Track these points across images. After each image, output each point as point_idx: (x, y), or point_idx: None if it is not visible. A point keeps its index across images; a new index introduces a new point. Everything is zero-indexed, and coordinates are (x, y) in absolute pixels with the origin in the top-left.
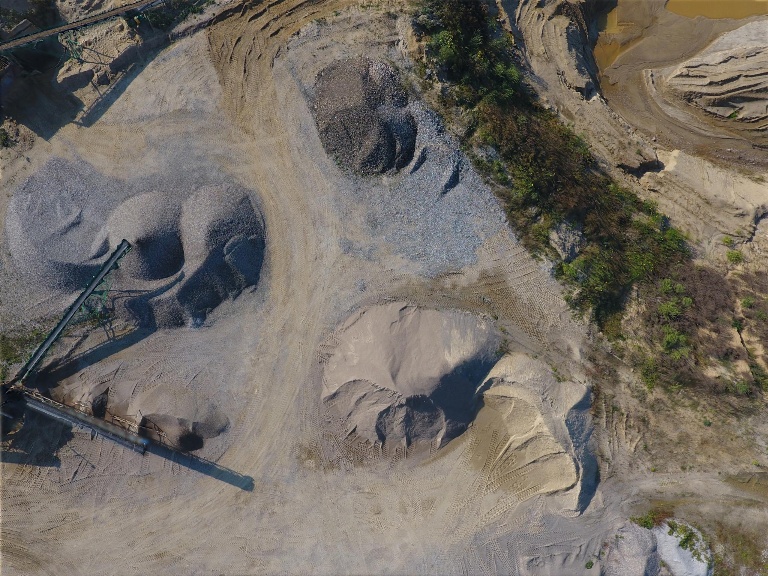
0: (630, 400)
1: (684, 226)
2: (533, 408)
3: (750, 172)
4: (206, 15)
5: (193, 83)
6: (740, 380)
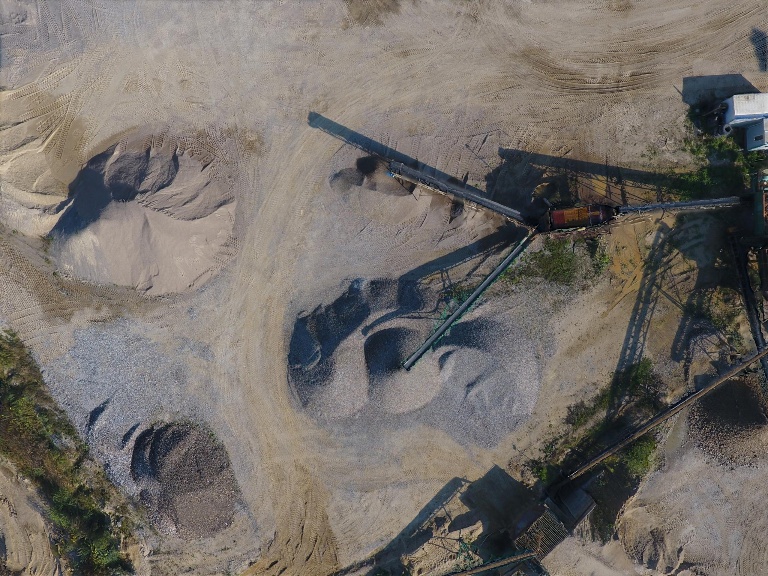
0: None
1: None
2: (10, 181)
3: None
4: None
5: (354, 517)
6: None
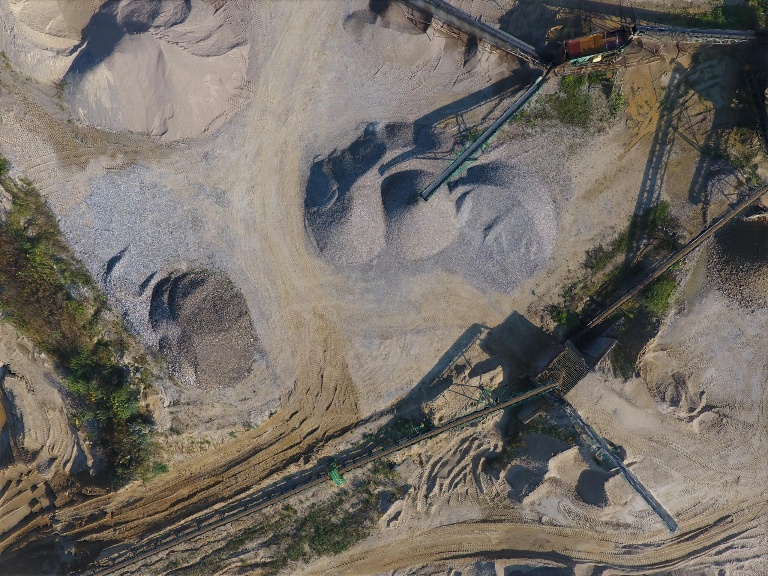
0: None
1: None
2: (23, 21)
3: None
4: (360, 432)
5: (373, 365)
6: None
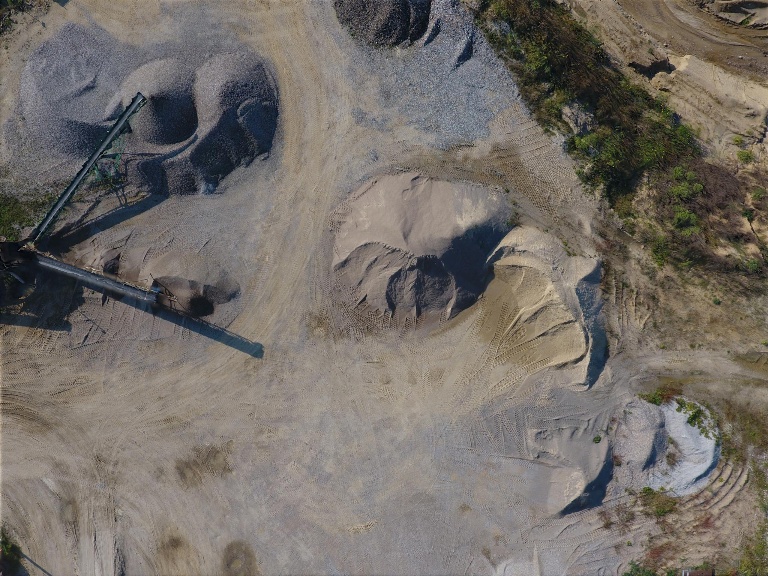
0: (640, 277)
1: (695, 125)
2: (544, 276)
3: (761, 79)
4: None
5: None
6: (750, 259)
